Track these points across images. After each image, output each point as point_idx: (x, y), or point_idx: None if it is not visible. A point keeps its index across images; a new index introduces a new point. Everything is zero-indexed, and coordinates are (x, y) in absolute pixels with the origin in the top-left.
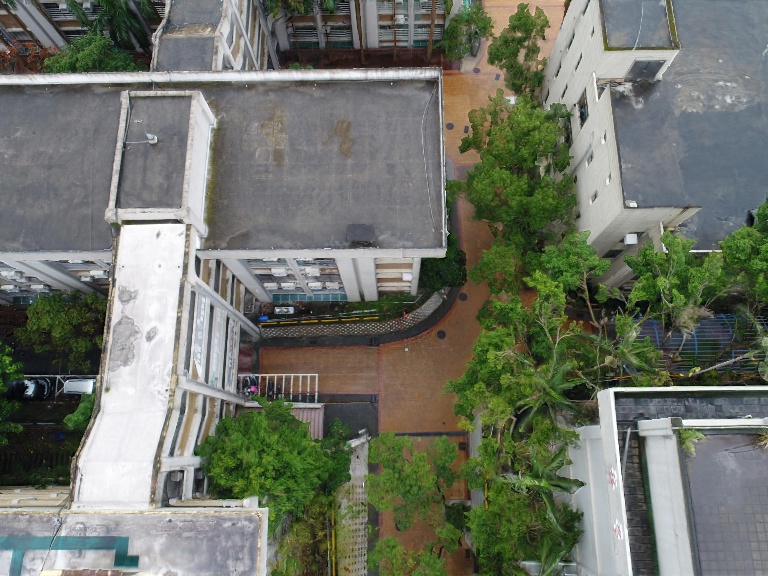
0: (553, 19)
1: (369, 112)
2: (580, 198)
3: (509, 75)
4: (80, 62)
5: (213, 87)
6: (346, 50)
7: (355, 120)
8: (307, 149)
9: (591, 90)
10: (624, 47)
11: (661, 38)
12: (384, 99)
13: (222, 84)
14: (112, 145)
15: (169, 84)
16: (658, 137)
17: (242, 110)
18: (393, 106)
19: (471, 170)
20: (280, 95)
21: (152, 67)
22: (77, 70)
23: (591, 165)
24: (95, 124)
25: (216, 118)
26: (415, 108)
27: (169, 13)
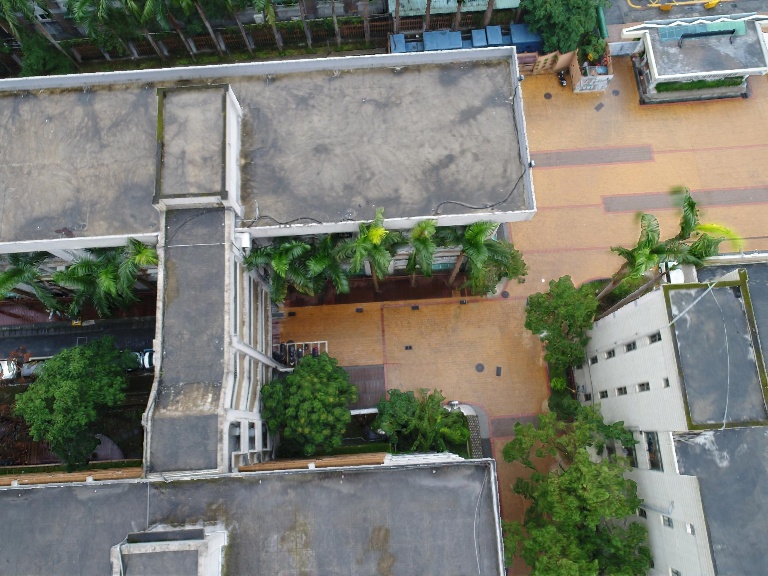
0: (586, 223)
1: (410, 513)
2: (653, 547)
3: (552, 348)
4: (58, 401)
5: (220, 485)
6: (358, 279)
7: (394, 526)
8: (339, 571)
9: (667, 449)
10: (711, 424)
11: (754, 407)
12: (426, 494)
13: (231, 480)
14: (103, 574)
15: (167, 483)
16: (750, 506)
17: (257, 517)
18: (438, 503)
19: (528, 542)
20: (301, 493)
21: (145, 463)
22: (55, 411)
23: (670, 533)
24: (81, 544)
25: (226, 530)
26: (464, 505)
27: (160, 370)
